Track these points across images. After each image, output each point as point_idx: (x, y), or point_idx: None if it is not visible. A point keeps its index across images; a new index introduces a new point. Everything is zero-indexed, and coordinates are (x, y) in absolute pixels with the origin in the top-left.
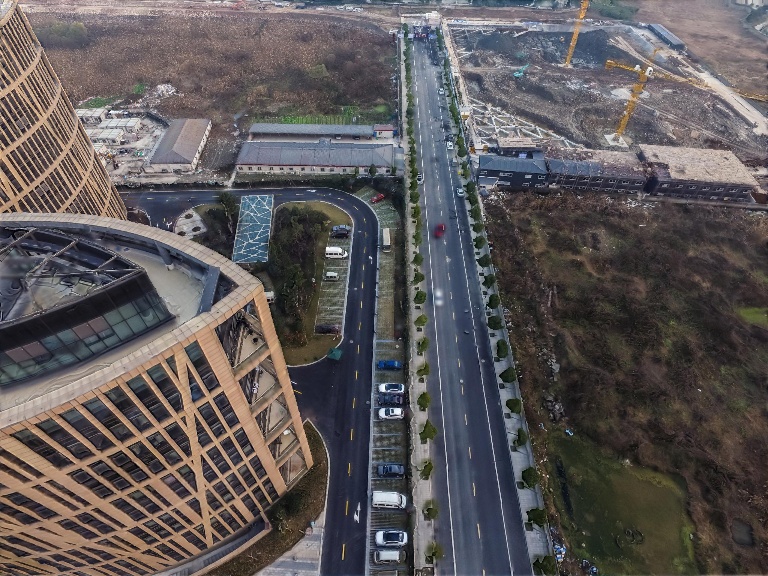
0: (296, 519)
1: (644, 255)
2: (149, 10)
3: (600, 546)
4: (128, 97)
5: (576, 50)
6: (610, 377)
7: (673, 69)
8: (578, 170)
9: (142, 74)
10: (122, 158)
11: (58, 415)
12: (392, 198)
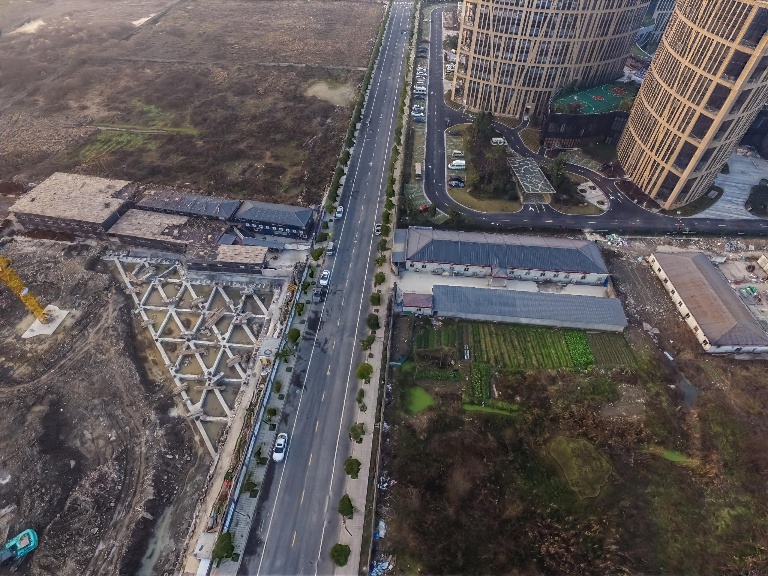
0: None
1: None
2: None
3: None
4: None
5: None
6: (306, 110)
7: None
8: None
9: None
10: (765, 287)
11: None
12: None
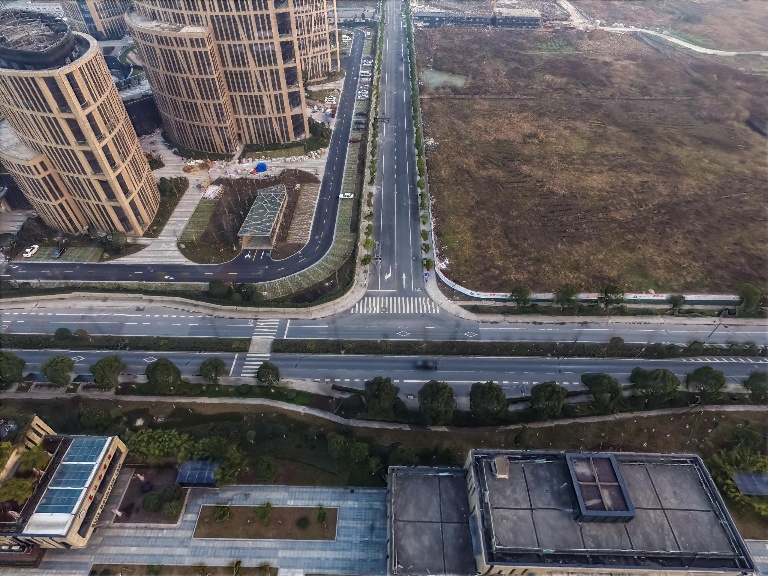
0: (335, 77)
1: (480, 38)
2: None
3: (434, 83)
4: None
5: None
6: None
7: None
8: (460, 15)
9: None
10: None
11: None
12: (372, 27)
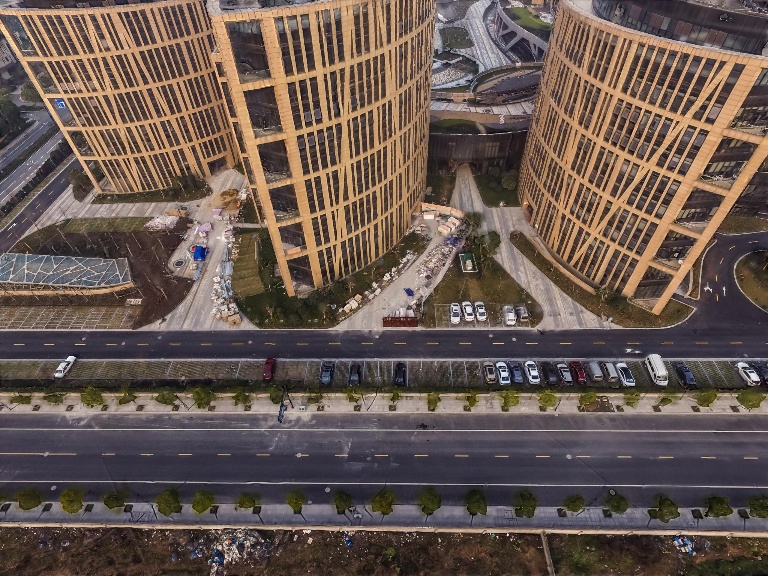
0: (609, 309)
1: None
2: None
3: None
4: None
5: None
6: None
7: None
8: None
9: None
10: None
11: (658, 49)
12: None
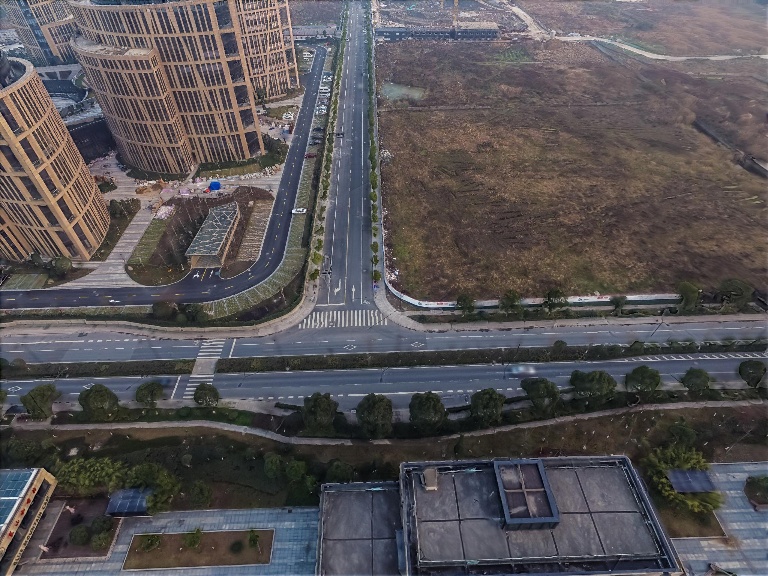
0: None
1: (439, 51)
2: None
3: None
4: None
5: (451, 4)
6: (410, 72)
7: (498, 6)
8: (420, 29)
9: None
10: None
11: None
12: (334, 44)
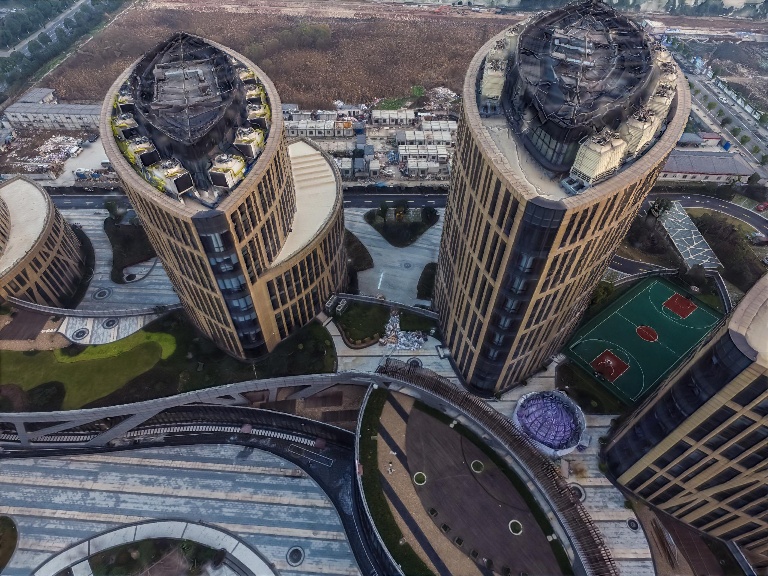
0: None
1: None
2: (353, 13)
3: None
4: (419, 99)
5: None
6: None
7: None
8: None
9: (415, 77)
10: None
11: None
12: None
